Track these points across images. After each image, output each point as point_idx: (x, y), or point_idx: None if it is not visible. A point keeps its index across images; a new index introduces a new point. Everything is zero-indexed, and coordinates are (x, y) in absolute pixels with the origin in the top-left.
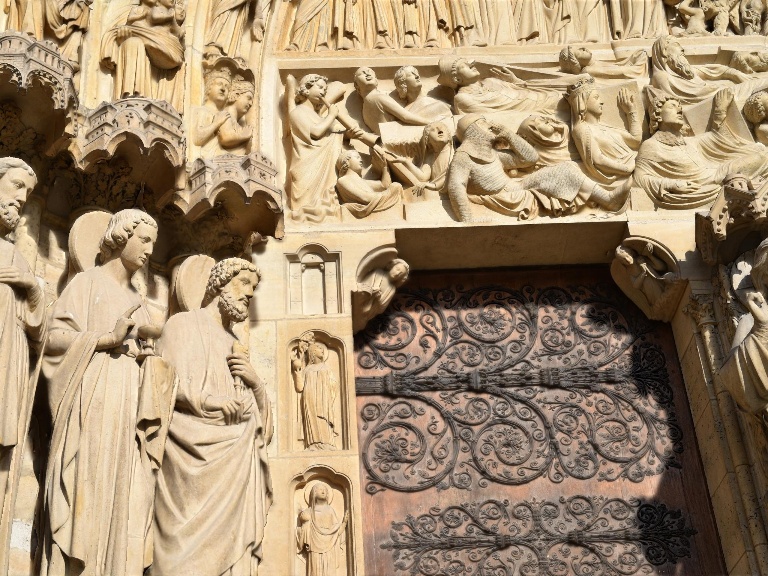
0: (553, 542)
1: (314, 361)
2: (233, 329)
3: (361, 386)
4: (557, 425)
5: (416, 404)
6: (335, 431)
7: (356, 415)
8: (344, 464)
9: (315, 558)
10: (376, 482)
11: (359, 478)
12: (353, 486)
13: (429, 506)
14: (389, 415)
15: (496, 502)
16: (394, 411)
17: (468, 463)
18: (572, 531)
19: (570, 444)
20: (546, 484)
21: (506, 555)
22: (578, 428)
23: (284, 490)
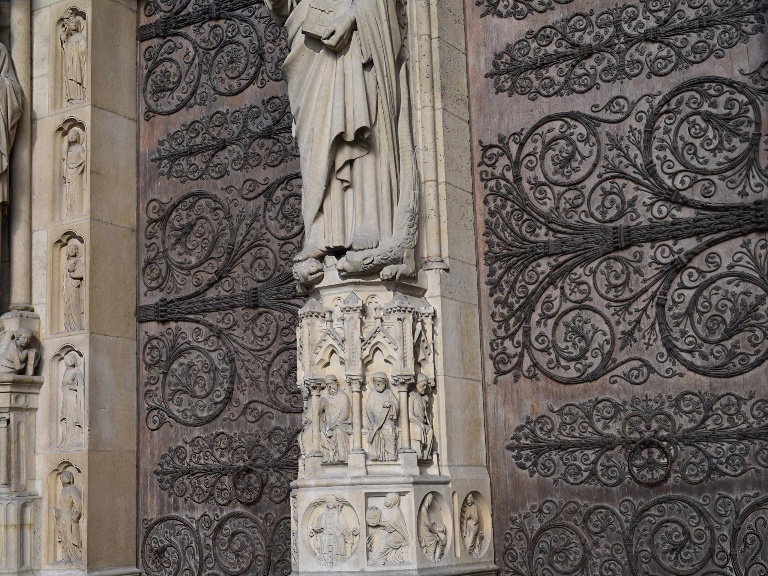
0: (253, 139)
1: (71, 34)
2: (12, 25)
3: (143, 33)
4: (266, 37)
5: (178, 40)
6: (85, 87)
7: (91, 73)
8: (83, 113)
9: (67, 186)
10: (150, 111)
11: (91, 123)
12: (87, 129)
13: (181, 123)
14: (161, 53)
15: (220, 112)
16: (164, 49)
17: (206, 83)
18: (263, 128)
19: (273, 52)
20: (254, 90)
21: (224, 154)
22: (281, 36)
23: (51, 140)
